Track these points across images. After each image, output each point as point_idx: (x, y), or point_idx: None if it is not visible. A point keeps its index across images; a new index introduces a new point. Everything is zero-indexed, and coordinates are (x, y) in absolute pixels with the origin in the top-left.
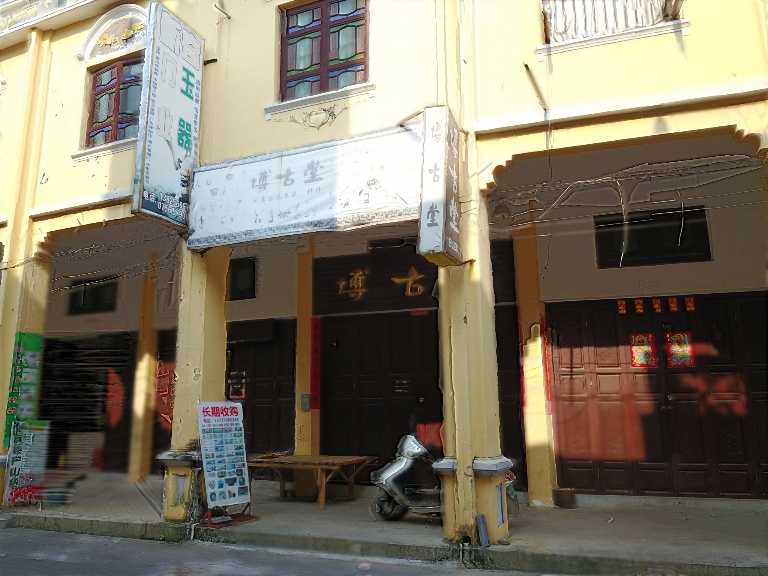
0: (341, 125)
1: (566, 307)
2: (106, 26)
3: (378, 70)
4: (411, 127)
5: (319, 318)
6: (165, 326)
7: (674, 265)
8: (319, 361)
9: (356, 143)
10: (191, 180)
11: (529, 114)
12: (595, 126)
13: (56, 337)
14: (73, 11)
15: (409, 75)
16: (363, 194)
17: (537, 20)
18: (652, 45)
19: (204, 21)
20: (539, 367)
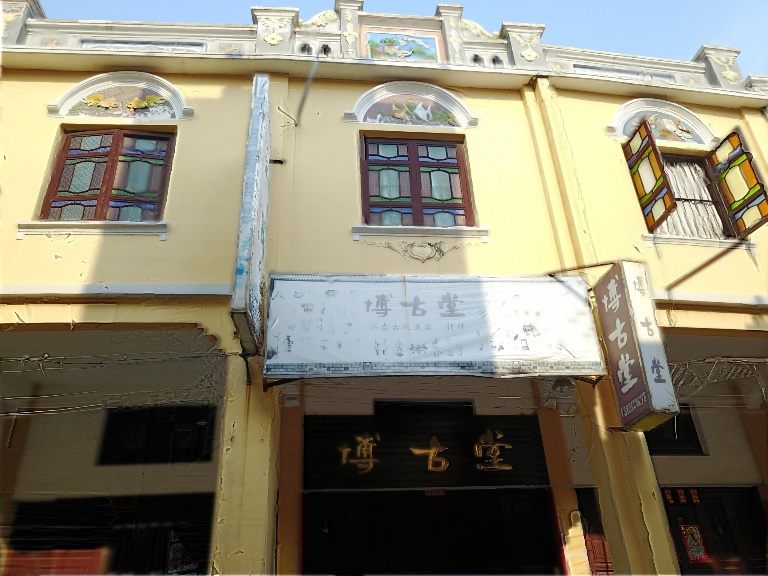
0: (451, 263)
1: (595, 494)
2: (102, 86)
3: (487, 218)
4: (563, 279)
5: (306, 494)
6: (188, 489)
7: (680, 457)
8: (306, 554)
9: (501, 284)
10: (268, 288)
11: (656, 291)
12: (708, 313)
13: None
14: (56, 56)
15: (522, 230)
16: (519, 339)
17: (636, 212)
18: (733, 255)
19: None
20: (586, 562)
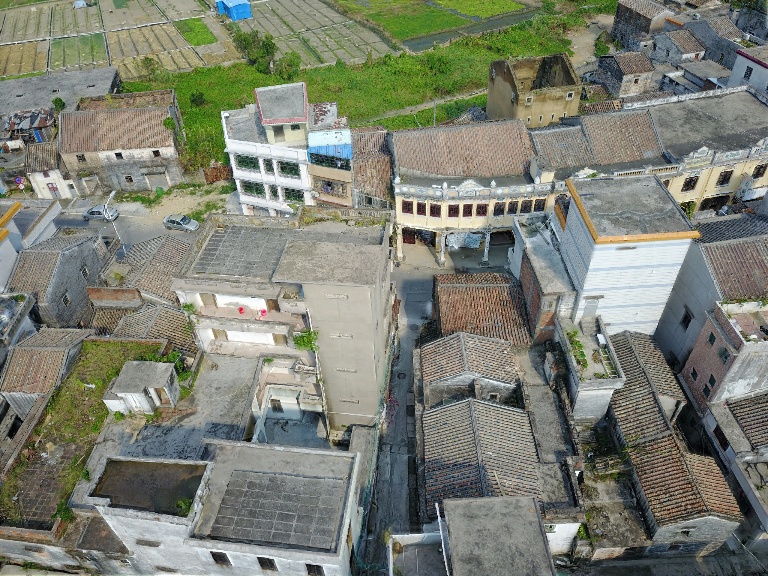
0: None
1: None
2: None
3: None
4: None
5: None
6: None
7: None
8: None
9: None
10: None
11: None
12: None
13: None
14: None
15: None
16: None
17: None
18: None
19: None
20: None
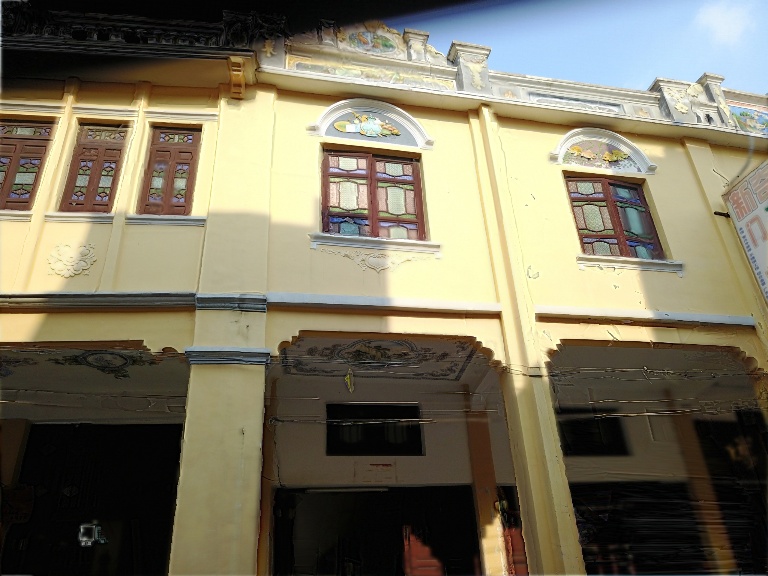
0: None
1: None
2: (577, 139)
3: None
4: None
5: None
6: None
7: None
8: None
9: None
10: None
11: None
12: None
13: (626, 480)
14: (546, 110)
15: None
16: None
17: None
18: None
19: (710, 179)
20: None
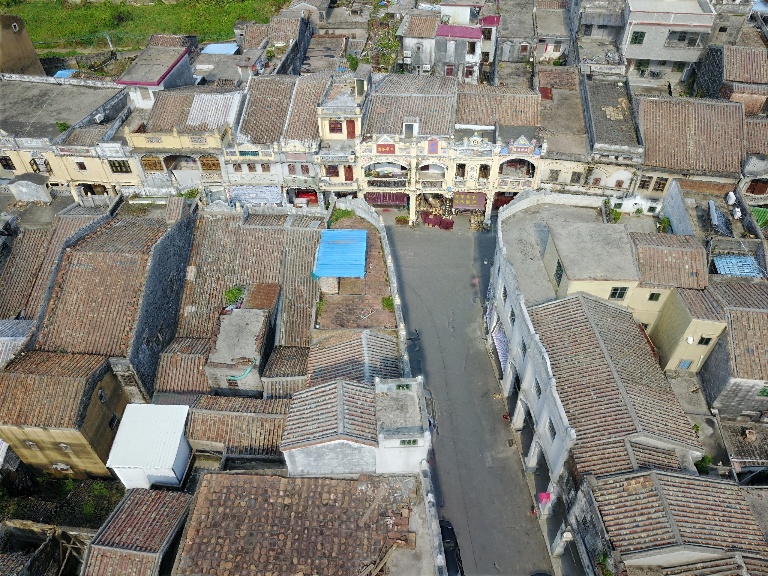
0: None
1: None
2: None
3: (17, 169)
4: None
5: None
6: None
7: None
8: None
9: None
10: None
11: None
12: None
13: None
14: None
15: None
16: None
17: None
18: None
19: None
20: None
